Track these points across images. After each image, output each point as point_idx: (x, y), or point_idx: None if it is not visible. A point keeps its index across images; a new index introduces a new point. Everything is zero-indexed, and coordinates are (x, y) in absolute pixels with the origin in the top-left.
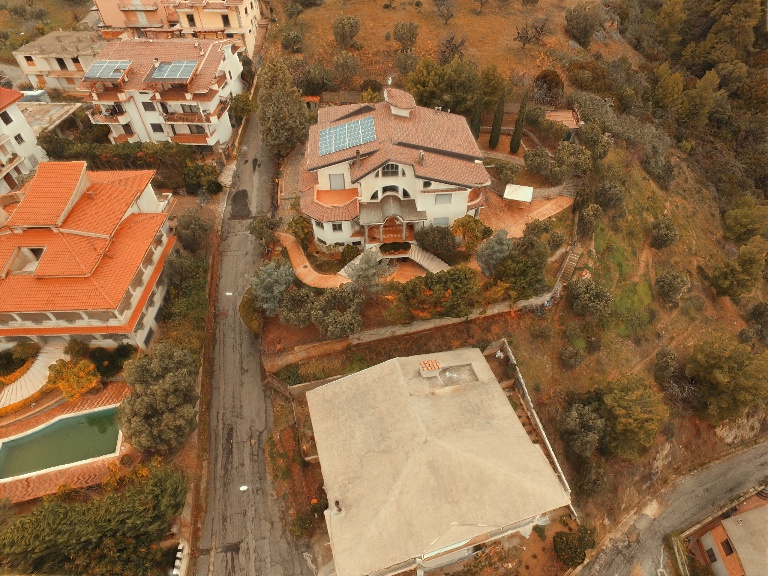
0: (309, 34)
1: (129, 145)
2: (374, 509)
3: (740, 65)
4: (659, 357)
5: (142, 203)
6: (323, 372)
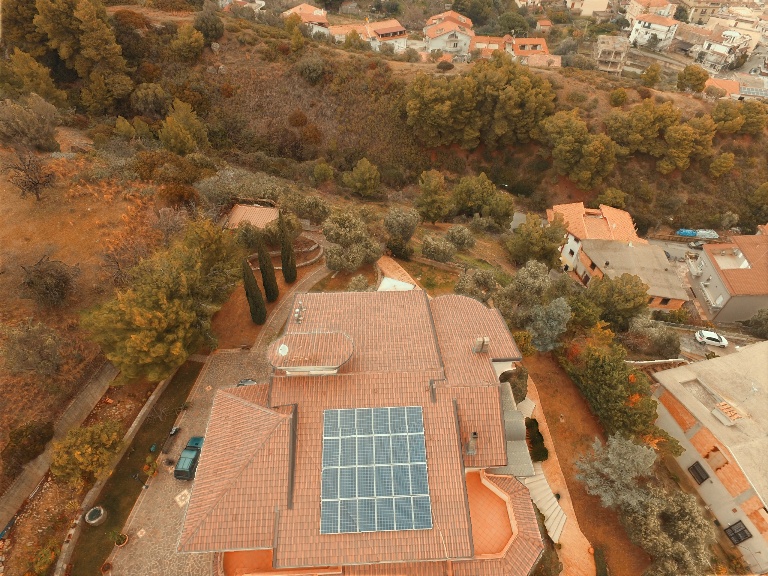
0: None
1: None
2: None
3: (152, 86)
4: None
5: None
6: (706, 572)
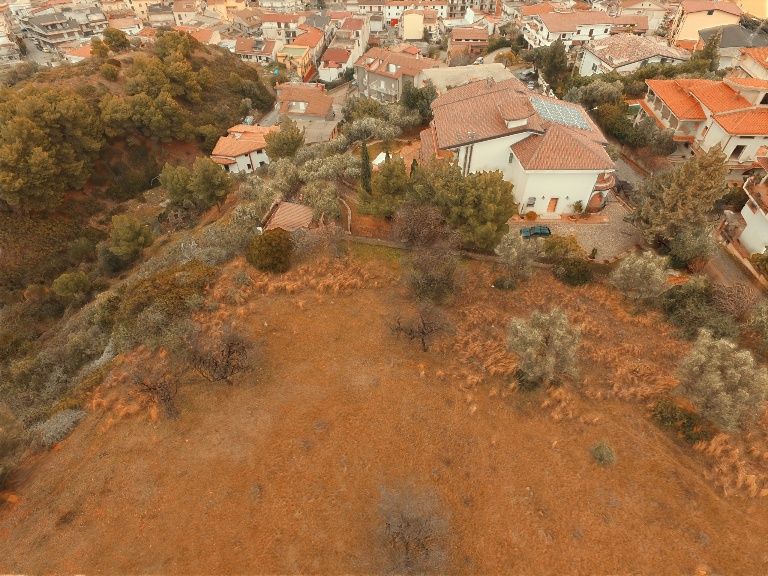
0: None
1: None
2: (493, 66)
3: None
4: (323, 148)
5: (714, 131)
6: None
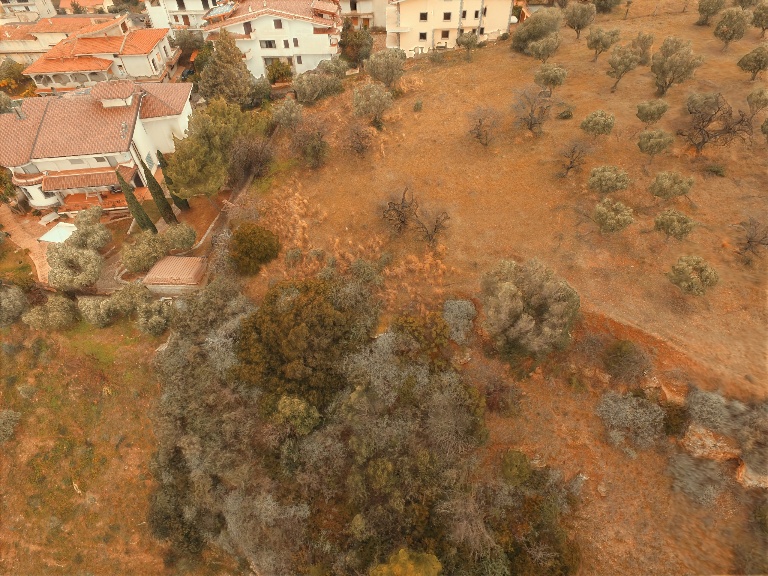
0: (440, 68)
1: (207, 45)
2: None
3: None
4: None
5: (130, 63)
6: None
